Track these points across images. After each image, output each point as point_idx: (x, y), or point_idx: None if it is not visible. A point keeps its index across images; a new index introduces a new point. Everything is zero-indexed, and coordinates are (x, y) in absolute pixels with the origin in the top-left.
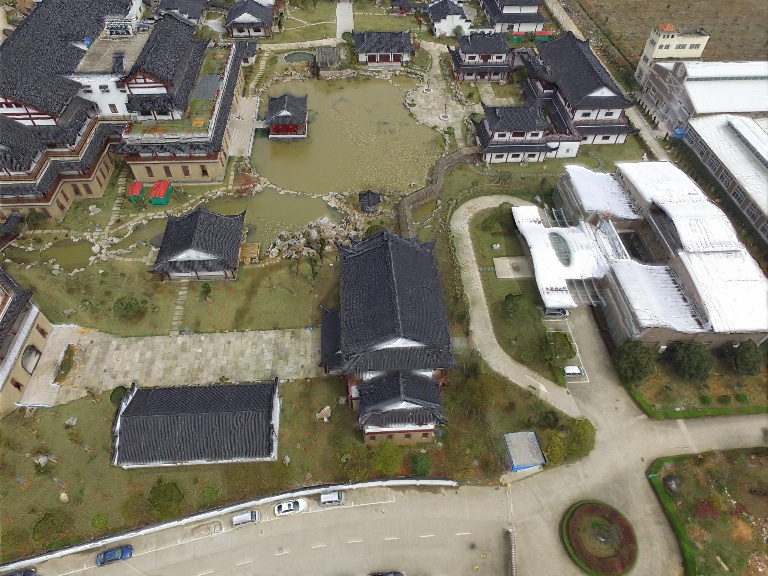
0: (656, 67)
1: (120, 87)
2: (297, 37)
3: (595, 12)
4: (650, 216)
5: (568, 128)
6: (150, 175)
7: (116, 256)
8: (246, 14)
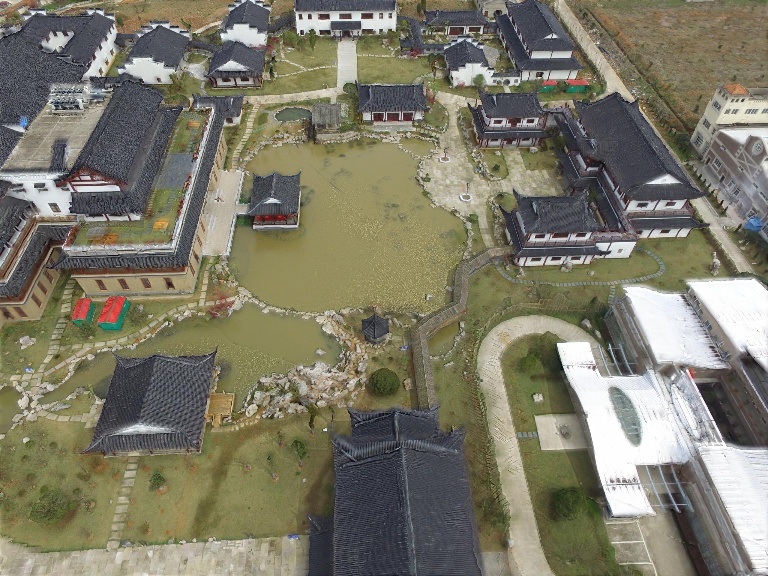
0: (721, 136)
1: (60, 186)
2: (291, 86)
3: (636, 53)
4: (744, 371)
5: (620, 222)
6: (102, 288)
7: (48, 413)
8: (232, 62)
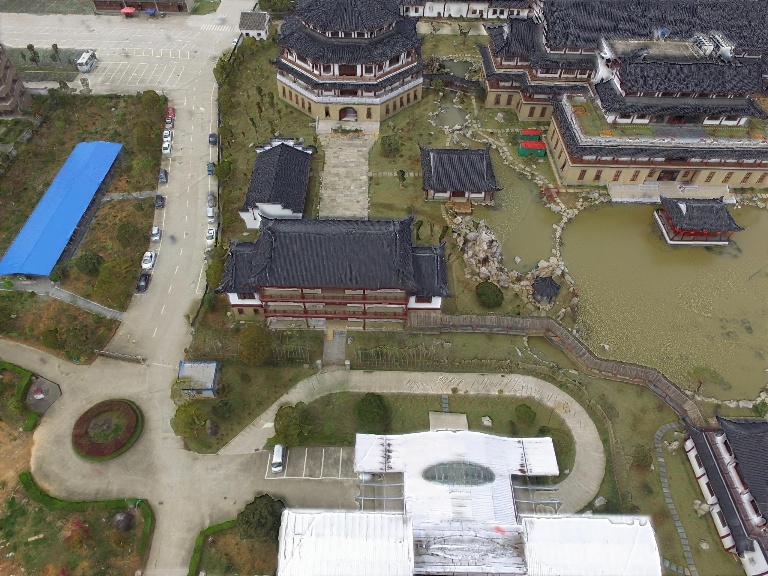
0: None
1: (611, 67)
2: None
3: None
4: None
5: None
6: None
7: None
8: None
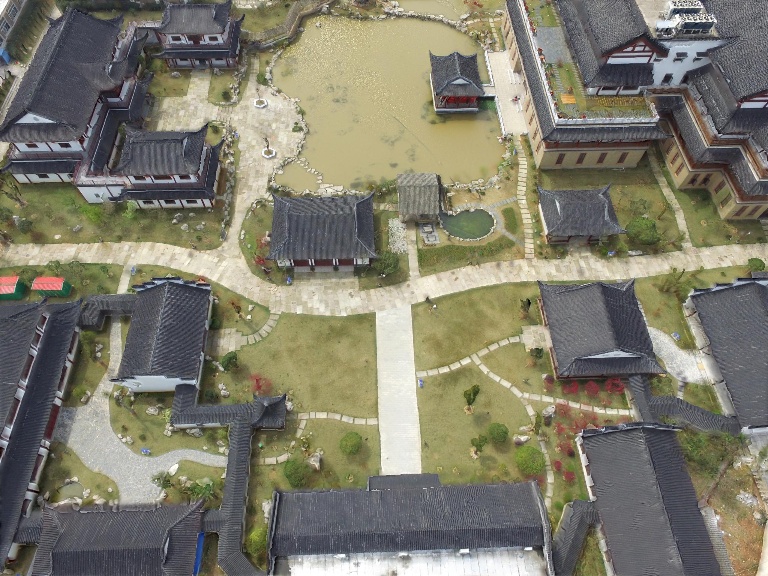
0: None
1: None
2: (489, 305)
3: None
4: None
5: None
6: None
7: None
8: None
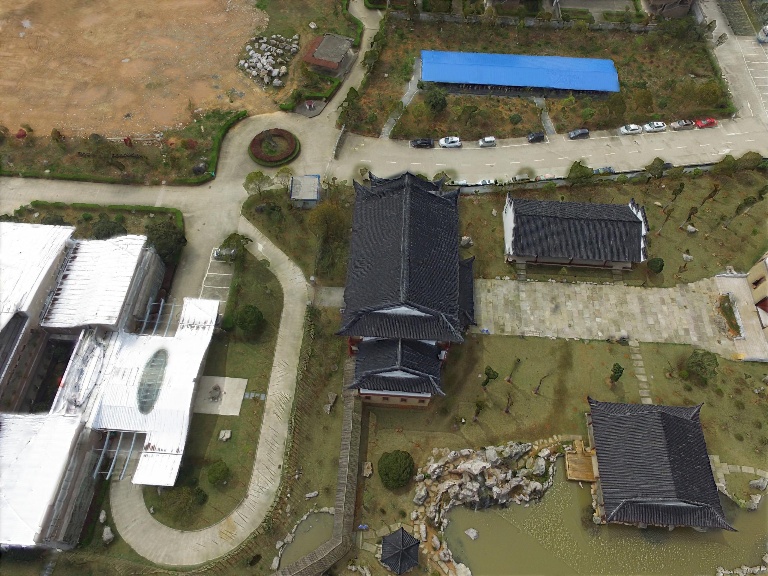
0: None
1: None
2: None
3: None
4: None
5: None
6: None
7: None
8: None
